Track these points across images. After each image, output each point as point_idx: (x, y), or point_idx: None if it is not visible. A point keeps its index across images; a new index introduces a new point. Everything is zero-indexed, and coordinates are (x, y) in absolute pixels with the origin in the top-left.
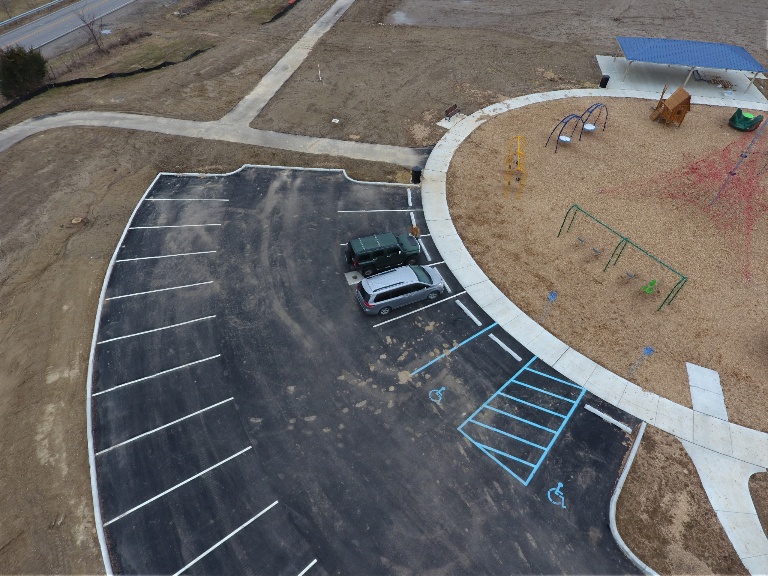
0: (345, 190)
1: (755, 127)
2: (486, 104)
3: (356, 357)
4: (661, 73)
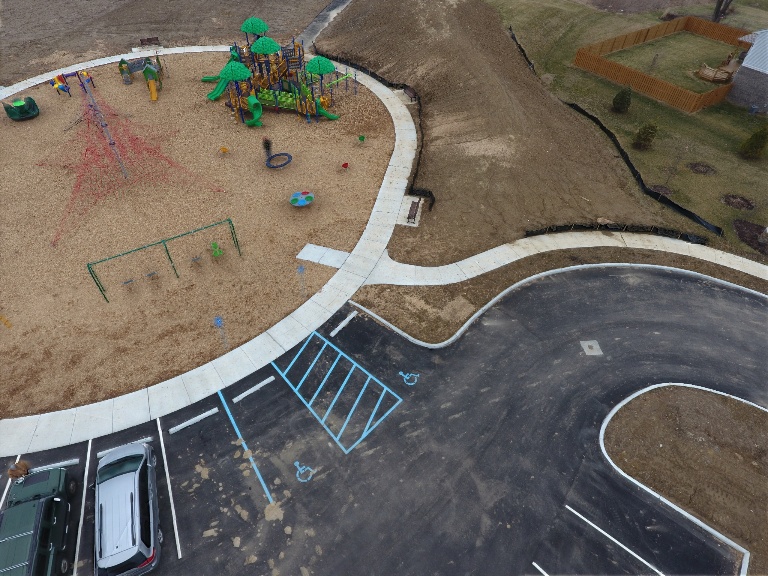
0: None
1: (37, 109)
2: None
3: None
4: None
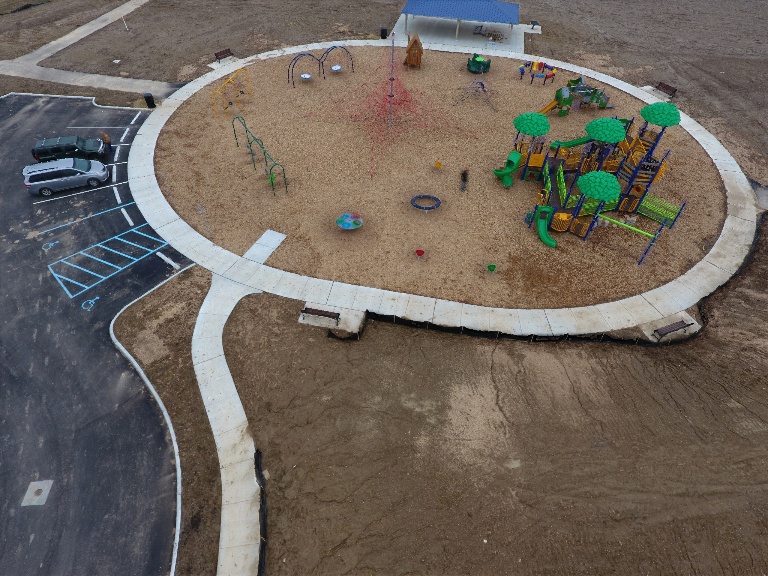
0: (85, 112)
1: (484, 69)
2: (265, 50)
3: (4, 222)
4: (447, 28)
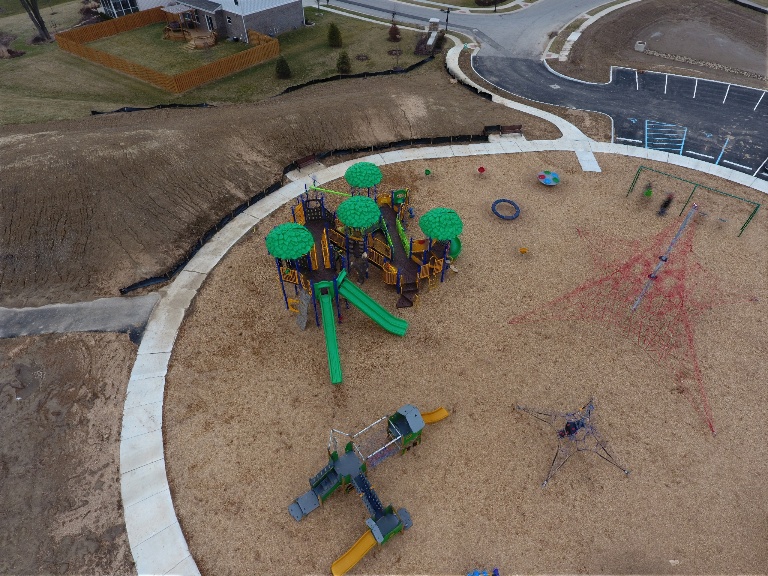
0: None
1: None
2: None
3: (762, 138)
4: None
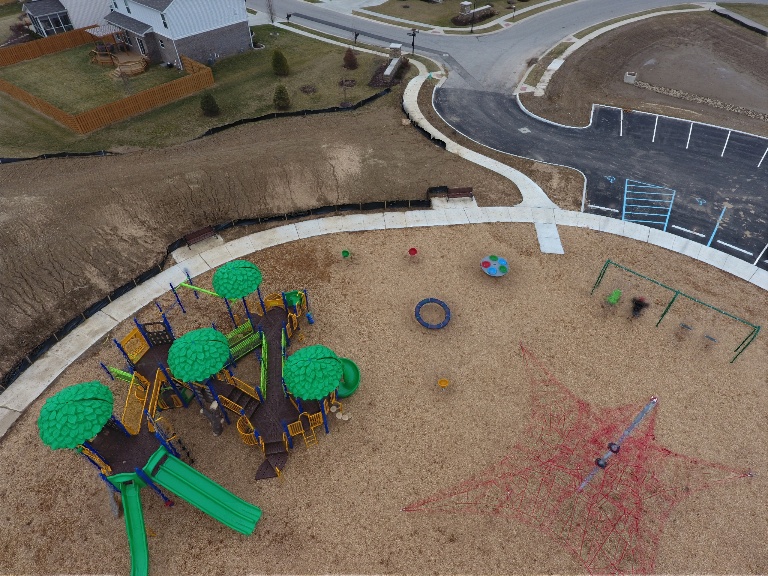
0: None
1: None
2: None
3: (767, 208)
4: None
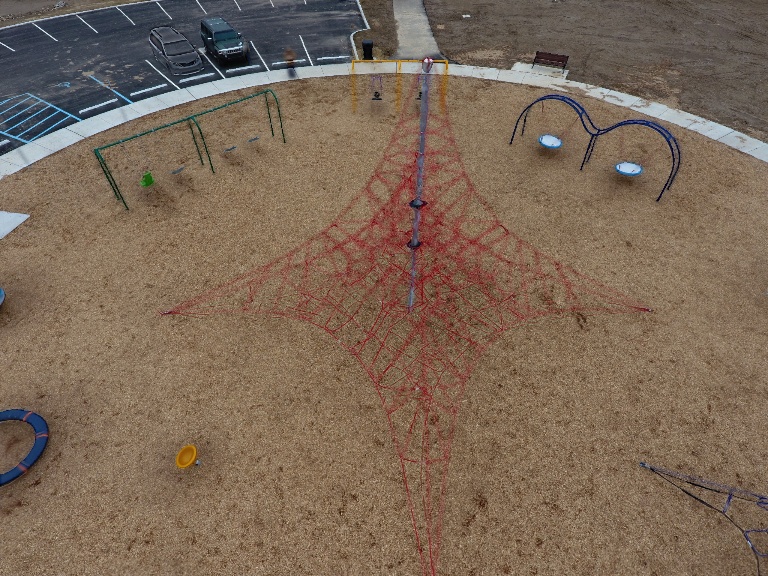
0: (335, 34)
1: None
2: (622, 89)
3: (116, 57)
4: None
